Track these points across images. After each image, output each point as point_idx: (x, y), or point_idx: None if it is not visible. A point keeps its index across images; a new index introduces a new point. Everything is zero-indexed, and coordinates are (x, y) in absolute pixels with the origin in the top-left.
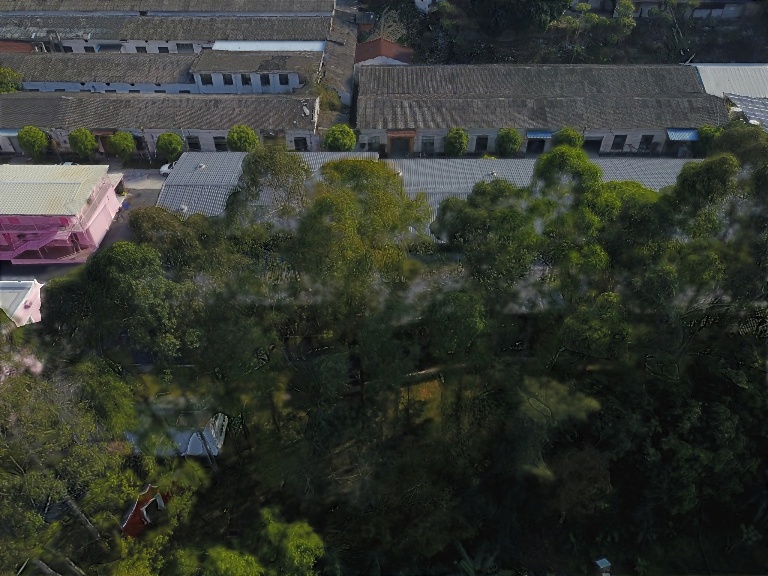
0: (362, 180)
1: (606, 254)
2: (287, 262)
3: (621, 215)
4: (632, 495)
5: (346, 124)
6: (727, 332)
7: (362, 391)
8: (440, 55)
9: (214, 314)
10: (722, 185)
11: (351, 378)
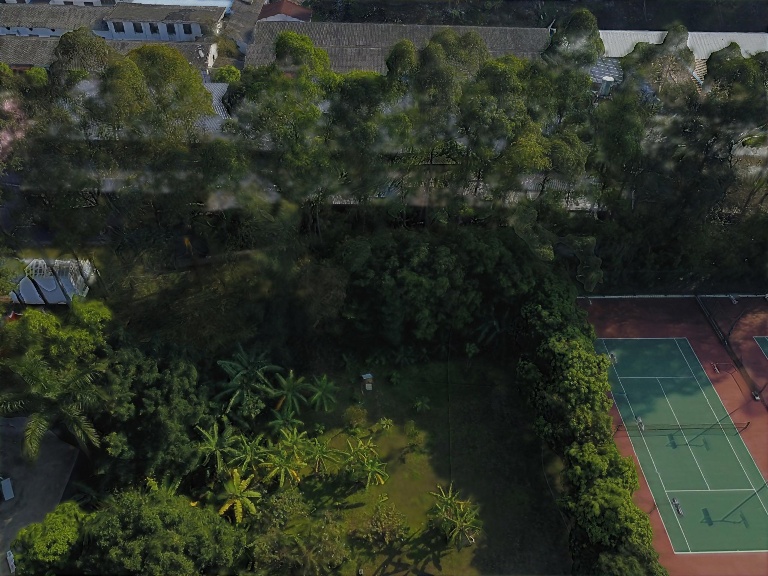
0: (156, 59)
1: (330, 114)
2: (108, 125)
3: (344, 87)
4: (377, 314)
5: (239, 68)
6: (454, 194)
7: (157, 218)
8: (338, 16)
9: (36, 149)
10: (403, 61)
11: (144, 204)
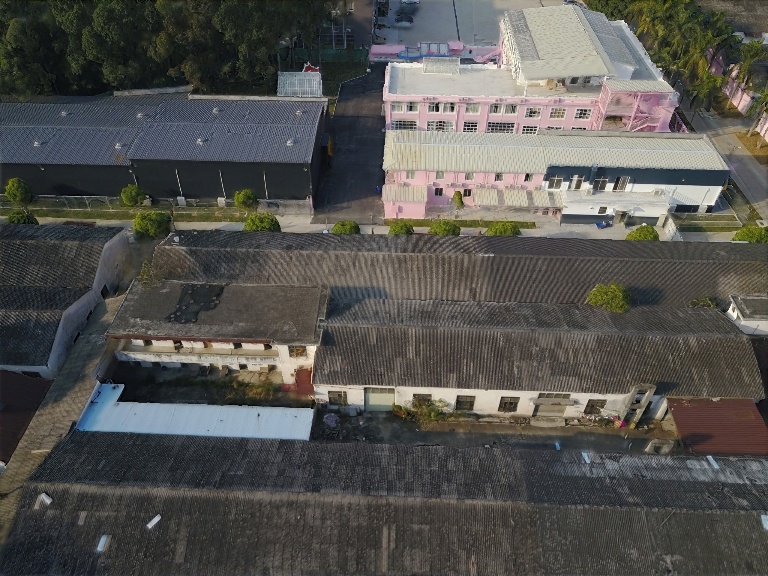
0: None
1: None
2: None
3: None
4: None
5: (131, 268)
6: None
7: None
8: None
9: None
10: None
11: None
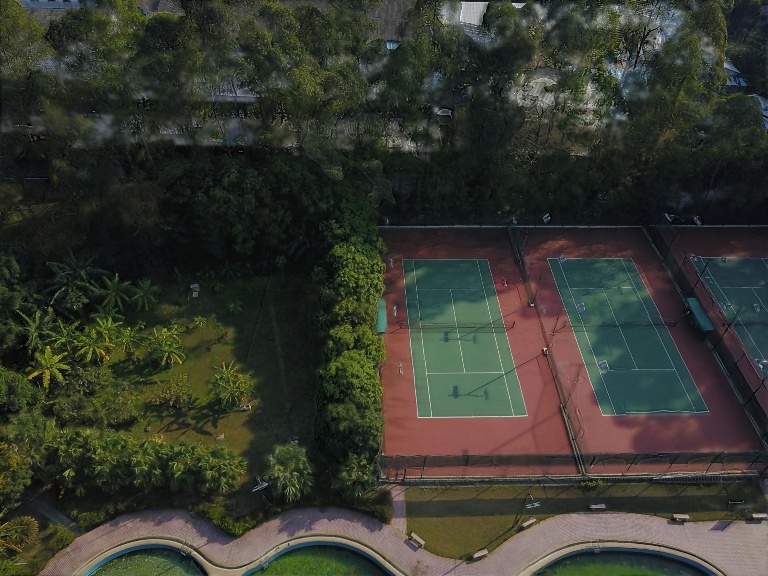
0: None
1: (134, 48)
2: None
3: None
4: (195, 228)
5: None
6: None
7: None
8: None
9: None
10: (190, 1)
11: None
